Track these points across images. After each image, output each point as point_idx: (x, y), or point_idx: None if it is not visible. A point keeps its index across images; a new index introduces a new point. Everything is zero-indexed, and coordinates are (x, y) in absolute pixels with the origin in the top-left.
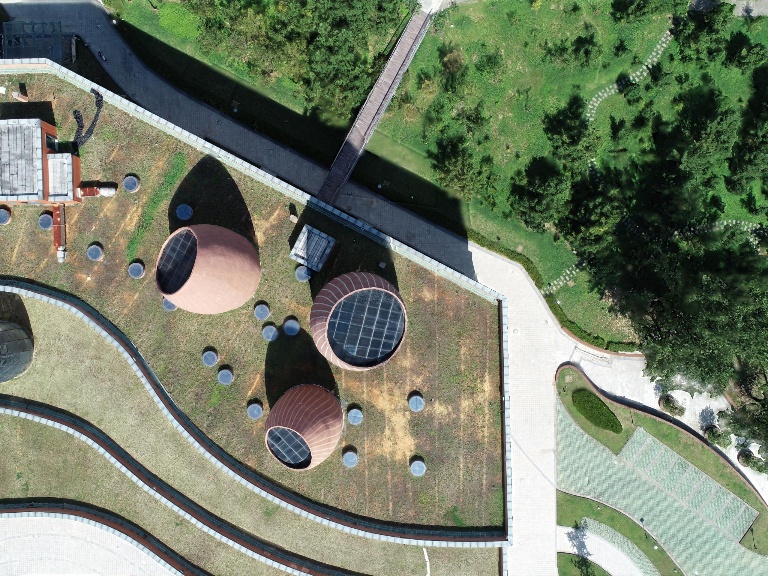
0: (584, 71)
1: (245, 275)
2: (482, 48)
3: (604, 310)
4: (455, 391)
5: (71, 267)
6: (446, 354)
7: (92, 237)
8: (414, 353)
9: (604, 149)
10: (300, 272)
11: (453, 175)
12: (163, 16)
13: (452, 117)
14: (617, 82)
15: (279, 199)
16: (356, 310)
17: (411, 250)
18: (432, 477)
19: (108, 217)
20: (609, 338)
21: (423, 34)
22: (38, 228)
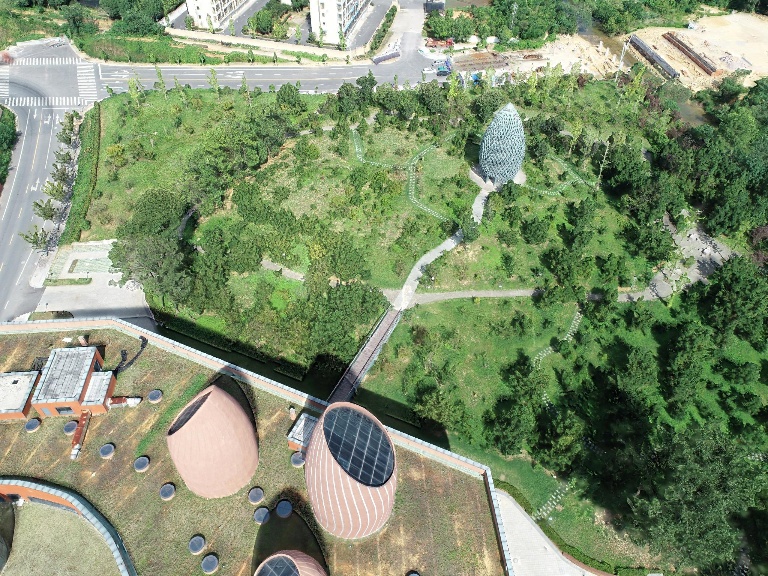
0: (523, 339)
1: (248, 435)
2: (442, 328)
3: (600, 533)
4: (454, 569)
5: (80, 466)
6: (440, 530)
7: (108, 439)
8: (407, 530)
9: (555, 392)
10: (296, 457)
11: (430, 405)
12: (199, 323)
13: (425, 375)
14: (551, 346)
15: (281, 403)
16: (349, 429)
17: (397, 432)
18: None
19: (127, 423)
20: (615, 563)
21: (396, 321)
22: (61, 434)
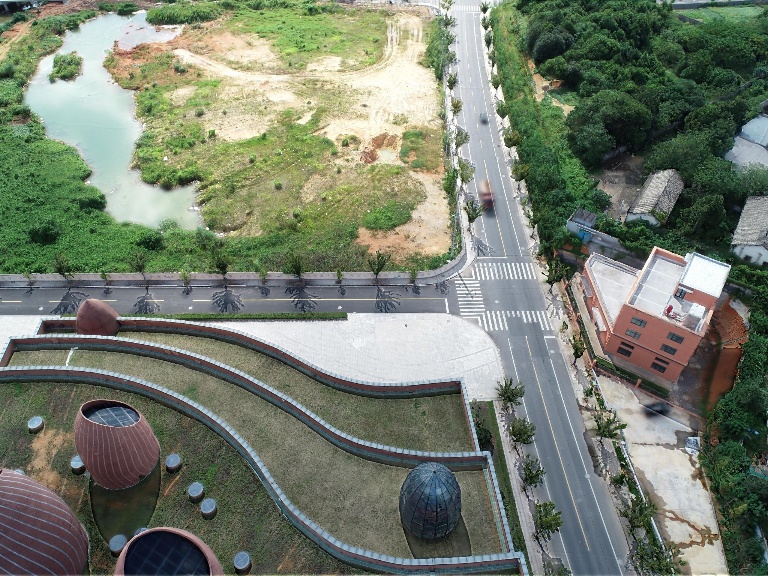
0: None
1: None
2: None
3: None
4: None
5: None
6: None
7: None
8: None
9: None
10: None
11: None
12: None
13: None
14: None
15: None
16: None
17: None
18: (27, 418)
19: None
20: None
21: None
22: None
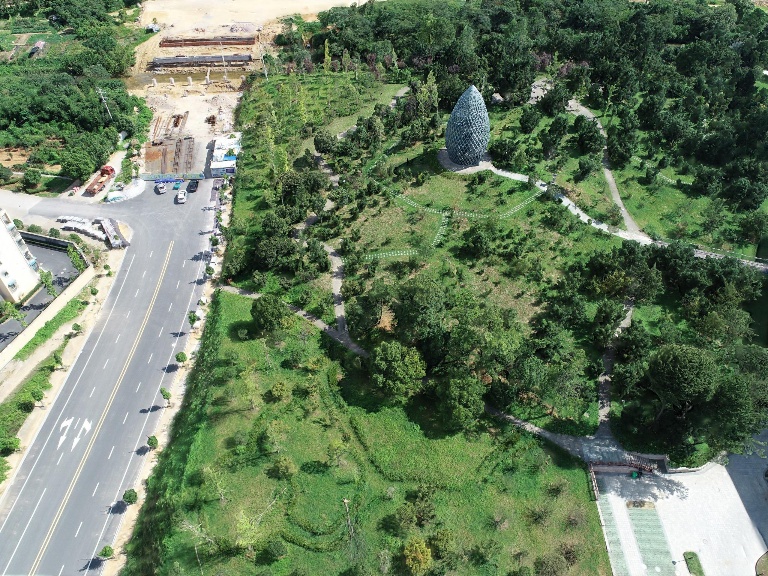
0: None
1: None
2: None
3: None
4: None
5: None
6: None
7: None
8: None
9: None
10: None
11: None
12: None
13: None
14: None
15: None
16: None
17: None
18: None
19: None
20: None
21: (669, 243)
22: None
